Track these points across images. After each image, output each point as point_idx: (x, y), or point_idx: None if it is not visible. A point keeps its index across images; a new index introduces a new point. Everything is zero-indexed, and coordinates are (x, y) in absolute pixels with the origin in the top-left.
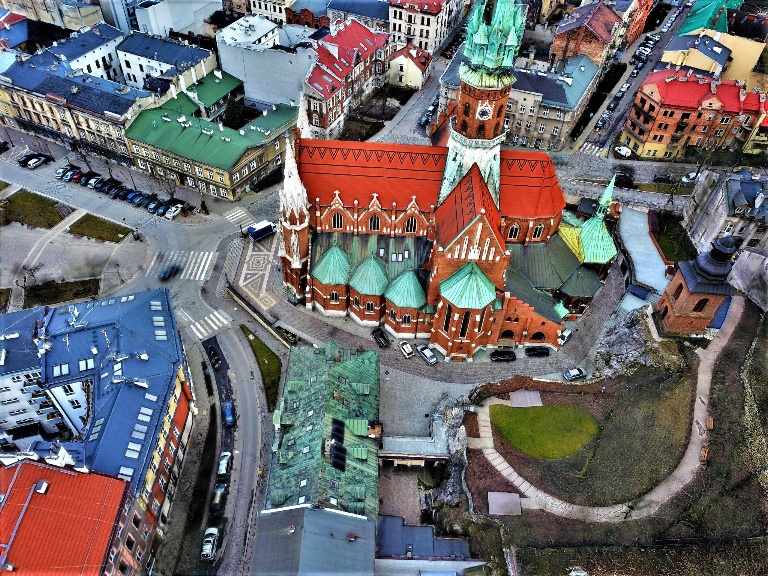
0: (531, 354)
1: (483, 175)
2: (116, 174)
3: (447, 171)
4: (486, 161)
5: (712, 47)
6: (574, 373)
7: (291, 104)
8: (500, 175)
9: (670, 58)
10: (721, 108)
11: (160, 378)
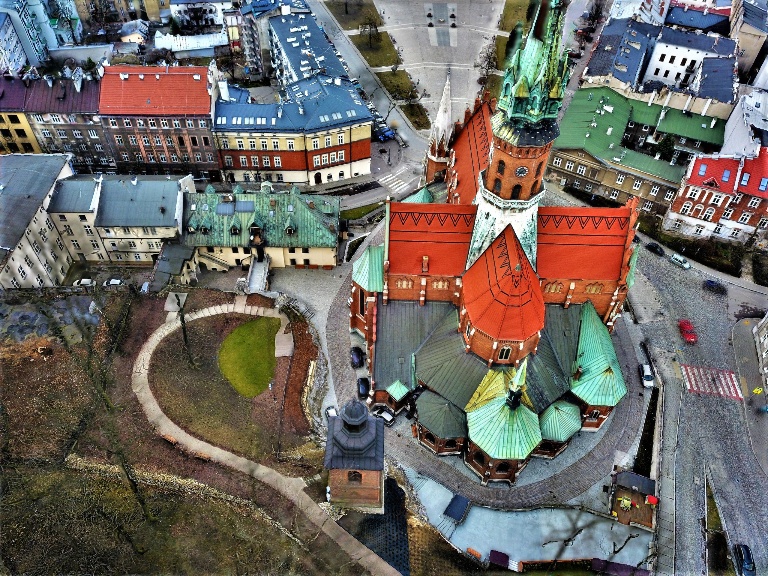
0: (359, 381)
1: None
2: (560, 116)
3: None
4: None
5: None
6: (331, 413)
7: None
8: (492, 245)
9: None
10: None
11: (289, 123)
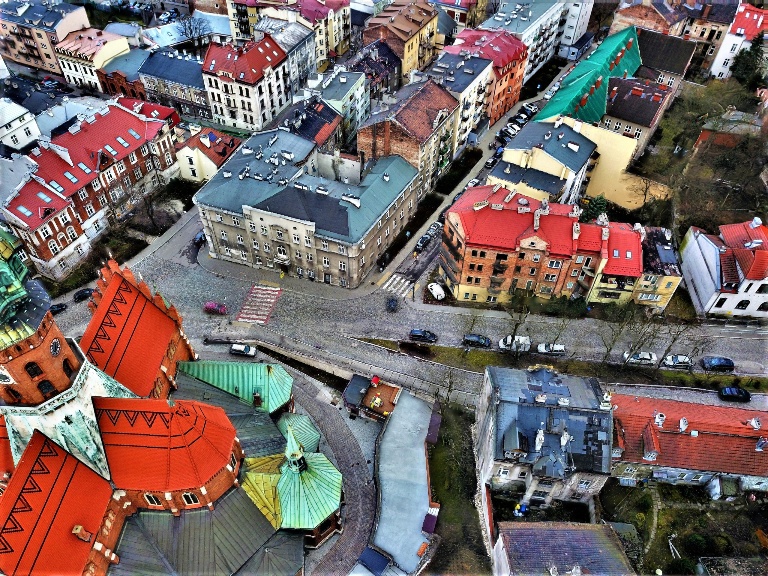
0: None
1: (58, 443)
2: None
3: (8, 433)
4: (51, 427)
5: (567, 143)
6: None
7: (3, 228)
8: (102, 432)
9: (512, 157)
10: (546, 250)
11: None
